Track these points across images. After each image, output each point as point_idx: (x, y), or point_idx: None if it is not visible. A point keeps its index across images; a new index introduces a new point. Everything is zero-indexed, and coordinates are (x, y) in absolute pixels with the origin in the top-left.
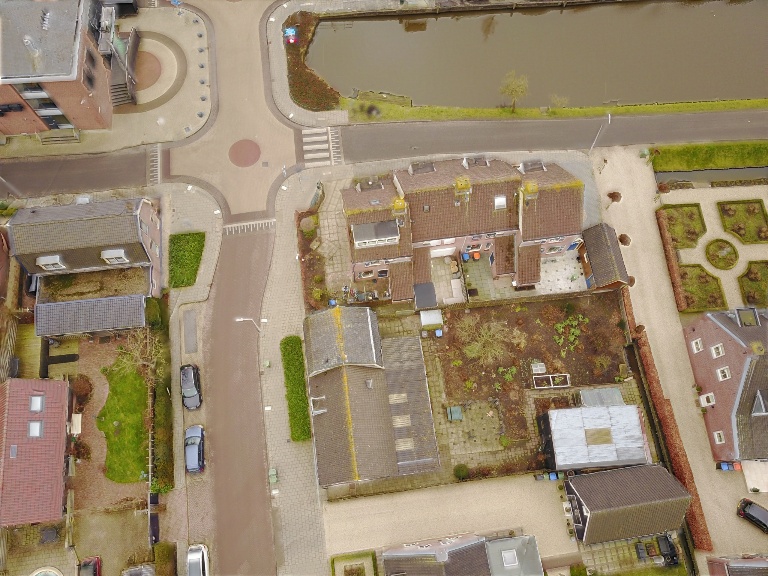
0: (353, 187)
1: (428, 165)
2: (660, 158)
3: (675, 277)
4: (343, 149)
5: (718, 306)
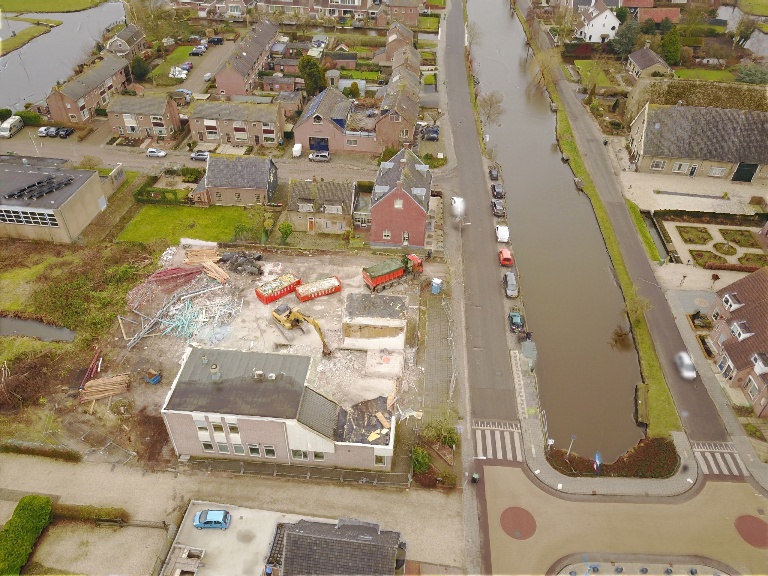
0: (759, 437)
1: (760, 356)
2: (655, 259)
3: (759, 268)
4: (716, 441)
5: (766, 258)
